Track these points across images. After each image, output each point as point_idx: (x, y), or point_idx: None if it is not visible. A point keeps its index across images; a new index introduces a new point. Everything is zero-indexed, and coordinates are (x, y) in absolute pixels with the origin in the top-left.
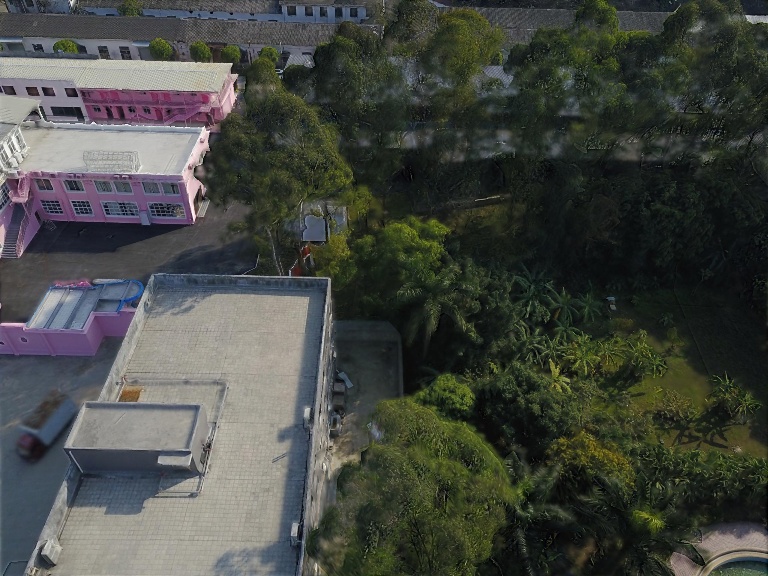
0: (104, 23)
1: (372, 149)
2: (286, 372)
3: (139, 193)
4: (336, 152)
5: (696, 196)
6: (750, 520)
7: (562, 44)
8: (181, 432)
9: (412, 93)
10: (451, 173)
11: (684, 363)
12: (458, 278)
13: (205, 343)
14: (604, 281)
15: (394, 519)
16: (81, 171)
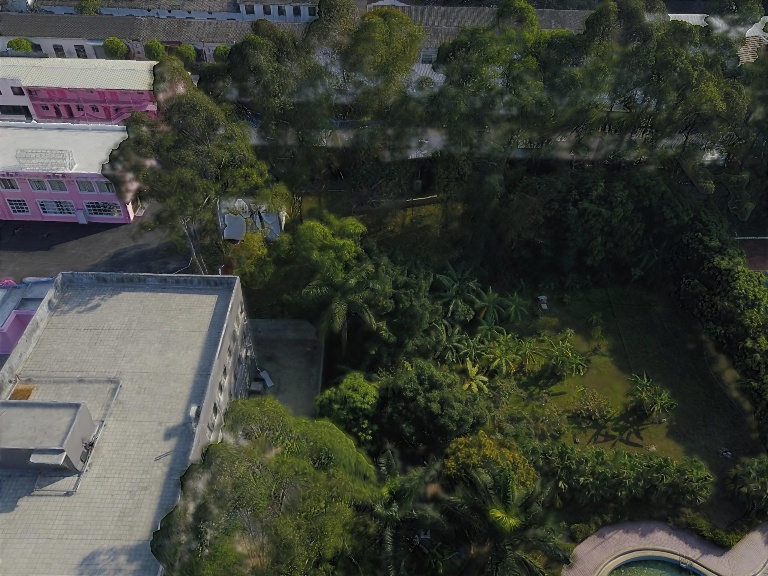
0: (59, 22)
1: (292, 147)
2: (183, 370)
3: (74, 191)
4: (245, 150)
5: (624, 195)
6: (655, 519)
7: (481, 42)
8: (58, 430)
9: (336, 91)
10: (373, 171)
11: (609, 362)
12: (371, 277)
13: (105, 341)
14: (537, 280)
15: (225, 517)
16: (15, 169)
